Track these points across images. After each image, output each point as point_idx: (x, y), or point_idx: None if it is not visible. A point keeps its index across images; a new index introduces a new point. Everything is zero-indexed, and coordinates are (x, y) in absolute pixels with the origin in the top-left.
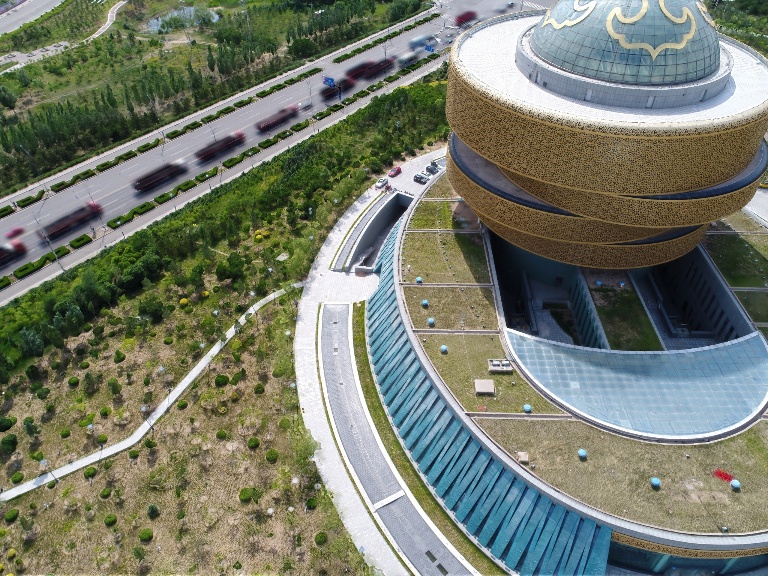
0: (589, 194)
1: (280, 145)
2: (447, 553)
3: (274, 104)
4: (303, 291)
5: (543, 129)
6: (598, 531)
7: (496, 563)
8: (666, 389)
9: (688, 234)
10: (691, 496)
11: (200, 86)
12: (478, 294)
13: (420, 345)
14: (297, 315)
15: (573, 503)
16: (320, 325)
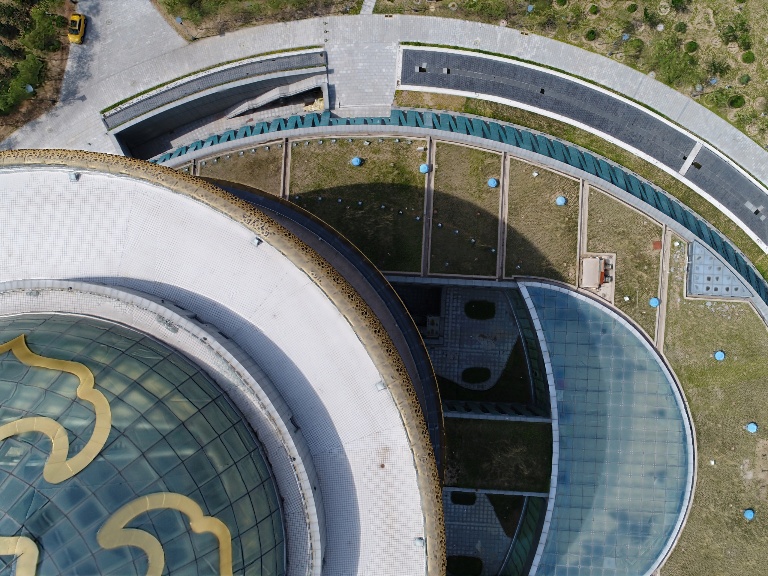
0: None
1: None
2: None
3: None
4: None
5: None
6: None
7: None
8: (619, 451)
9: None
10: (761, 479)
11: None
12: None
13: None
14: None
15: None
16: None
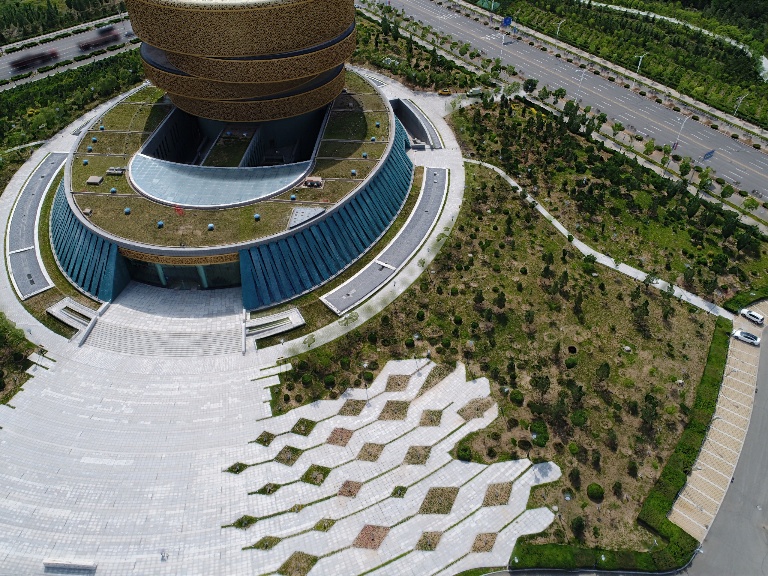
0: (191, 58)
1: (91, 59)
2: (40, 275)
3: (105, 32)
4: (42, 145)
5: (146, 7)
6: (110, 247)
7: (67, 279)
8: (215, 184)
9: (287, 97)
10: (179, 231)
11: (53, 18)
12: (138, 137)
13: (72, 160)
14: (28, 158)
15: (99, 231)
16: (41, 164)
